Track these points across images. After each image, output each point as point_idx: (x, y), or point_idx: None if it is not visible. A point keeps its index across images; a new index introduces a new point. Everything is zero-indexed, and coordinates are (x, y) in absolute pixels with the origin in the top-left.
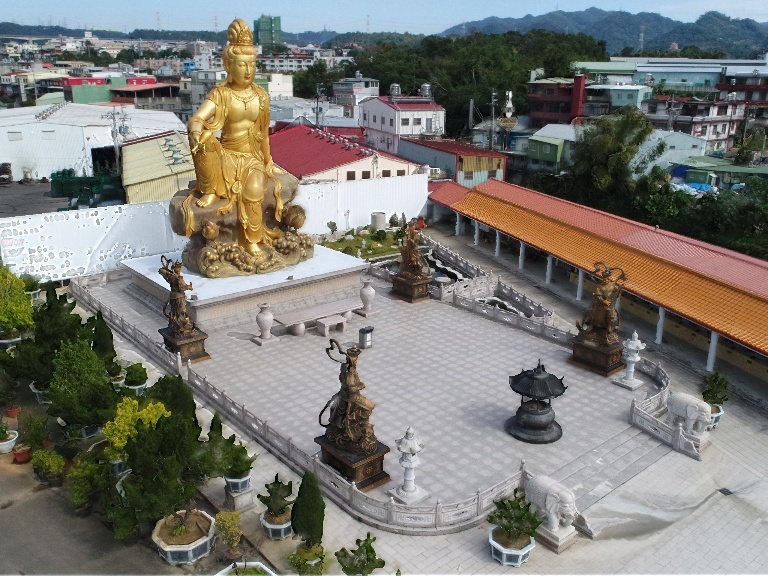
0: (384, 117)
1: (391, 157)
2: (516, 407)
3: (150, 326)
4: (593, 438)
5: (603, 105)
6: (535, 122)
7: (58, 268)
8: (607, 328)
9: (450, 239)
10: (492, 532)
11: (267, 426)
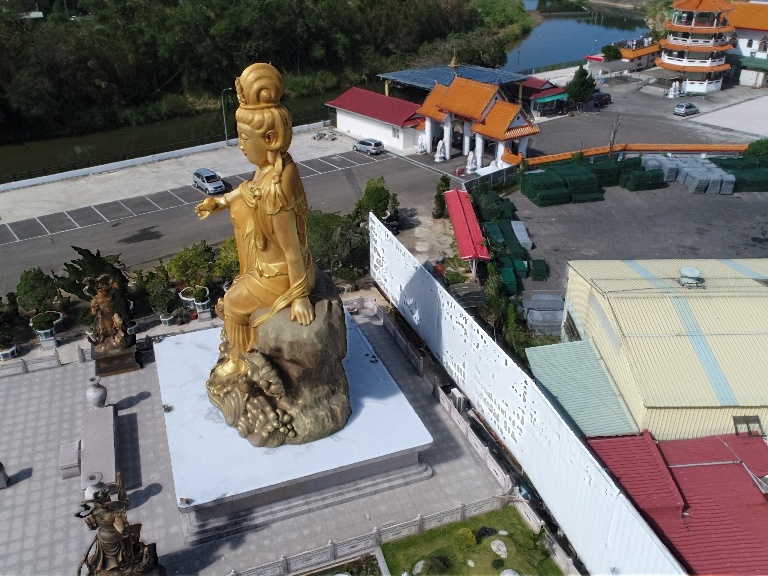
0: None
1: None
2: None
3: None
4: None
5: None
6: None
7: None
8: None
9: None
10: None
11: None
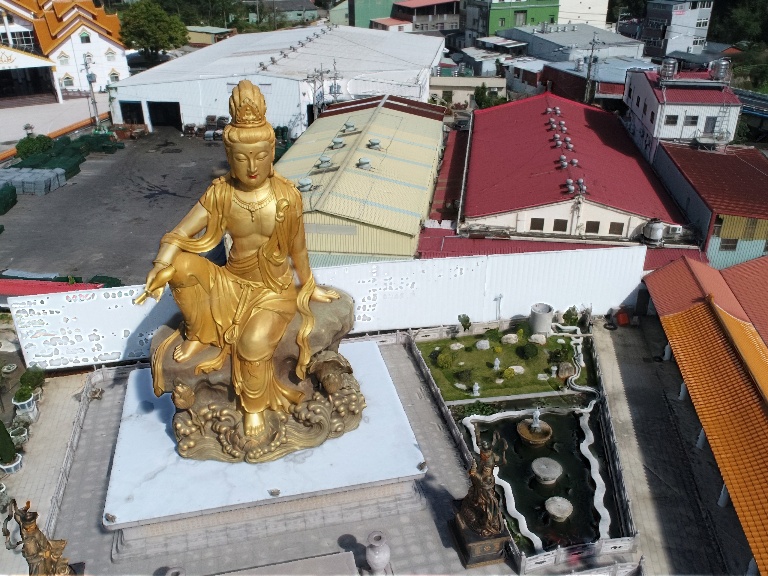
0: (646, 105)
1: (614, 193)
2: None
3: (92, 511)
4: None
5: None
6: None
7: (88, 351)
8: None
9: (647, 369)
10: None
11: None
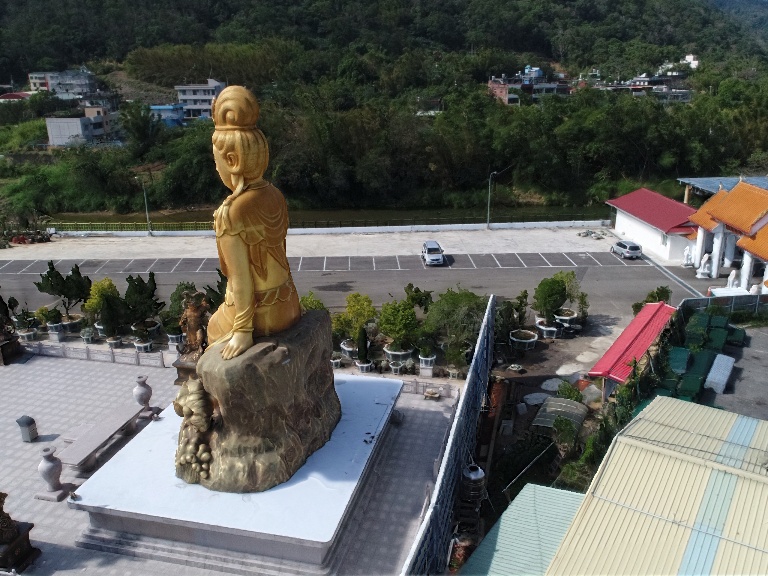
0: None
1: None
2: None
3: None
4: None
5: None
6: None
7: None
8: None
9: None
10: None
11: None
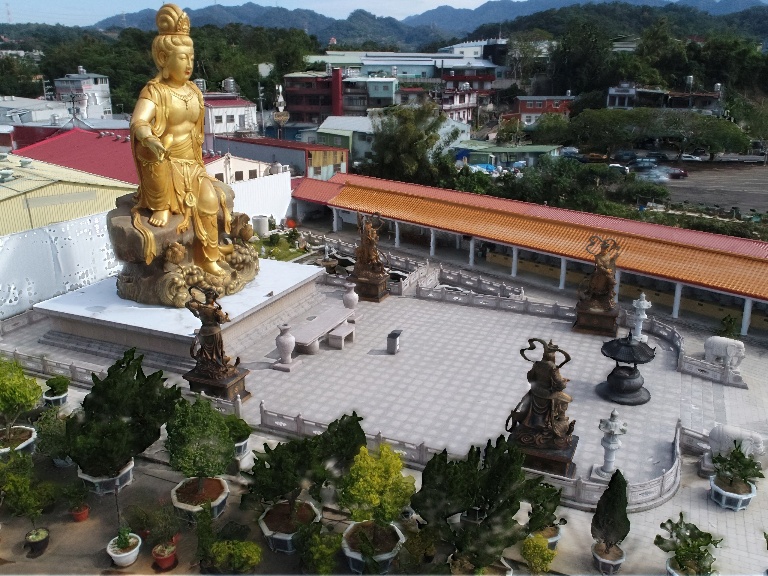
0: None
1: None
2: (586, 378)
3: None
4: (671, 389)
5: (361, 97)
6: (296, 116)
7: None
8: (609, 294)
9: (333, 236)
10: (715, 485)
11: (426, 448)
